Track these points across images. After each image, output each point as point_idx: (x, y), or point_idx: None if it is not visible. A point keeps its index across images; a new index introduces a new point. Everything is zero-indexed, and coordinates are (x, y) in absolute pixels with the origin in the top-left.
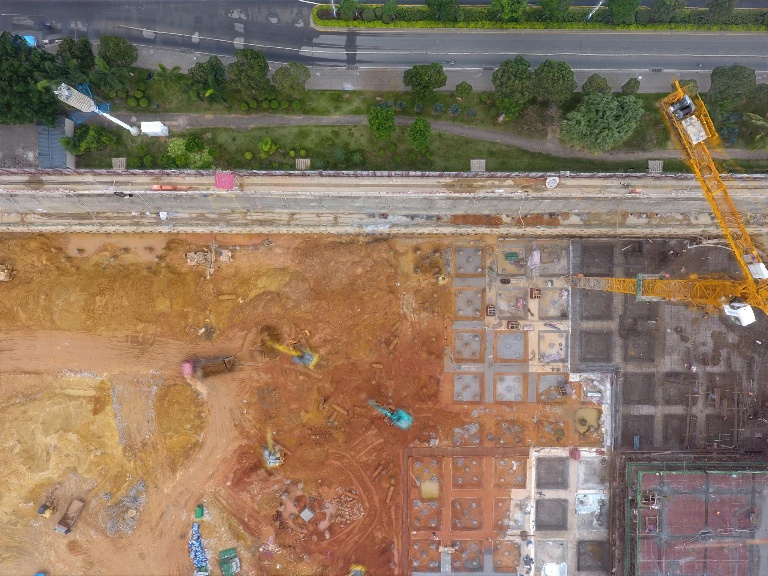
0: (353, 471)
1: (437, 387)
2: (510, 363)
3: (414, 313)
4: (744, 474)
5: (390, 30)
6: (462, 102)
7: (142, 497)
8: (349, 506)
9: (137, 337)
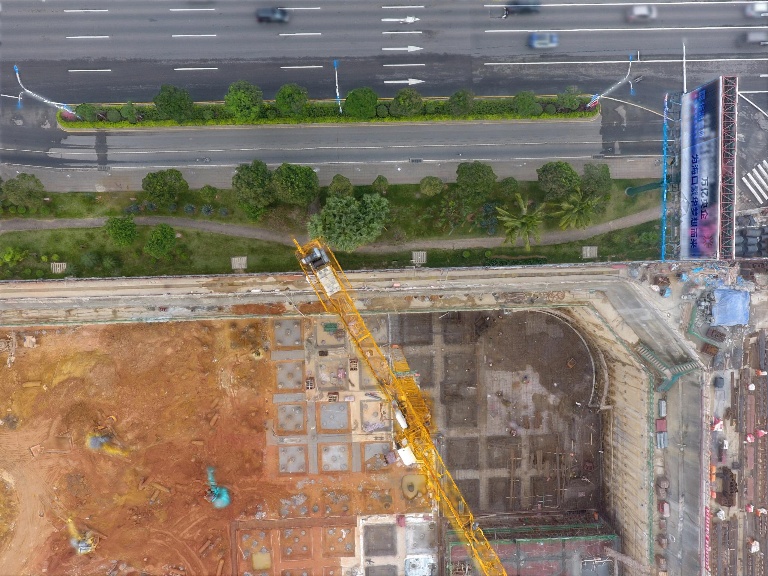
0: (179, 548)
1: (261, 460)
2: (333, 434)
3: (233, 388)
4: (554, 540)
5: (140, 129)
6: (219, 200)
7: None
8: None
9: None
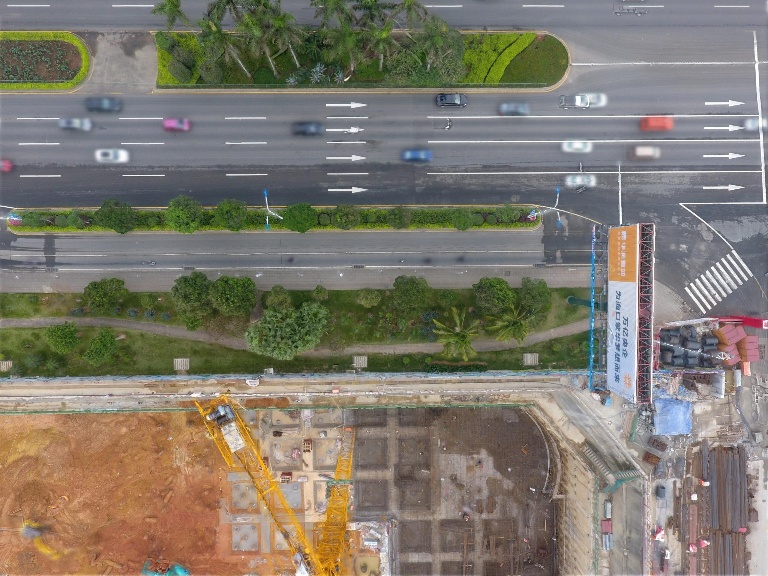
0: None
1: (214, 538)
2: (286, 513)
3: (188, 466)
4: None
5: (88, 233)
6: (163, 302)
7: None
8: None
9: None
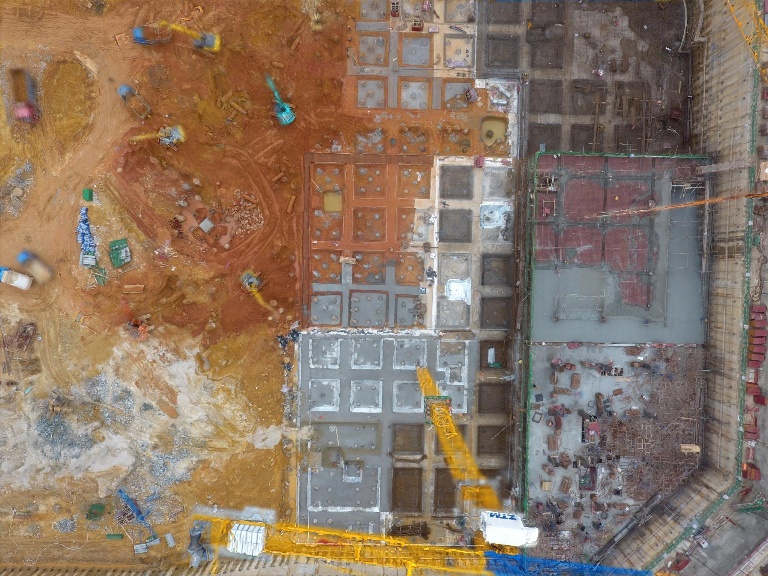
0: (252, 174)
1: (340, 92)
2: (415, 67)
3: (317, 12)
4: (644, 159)
5: None
6: None
7: (30, 180)
8: (248, 212)
9: (25, 9)
